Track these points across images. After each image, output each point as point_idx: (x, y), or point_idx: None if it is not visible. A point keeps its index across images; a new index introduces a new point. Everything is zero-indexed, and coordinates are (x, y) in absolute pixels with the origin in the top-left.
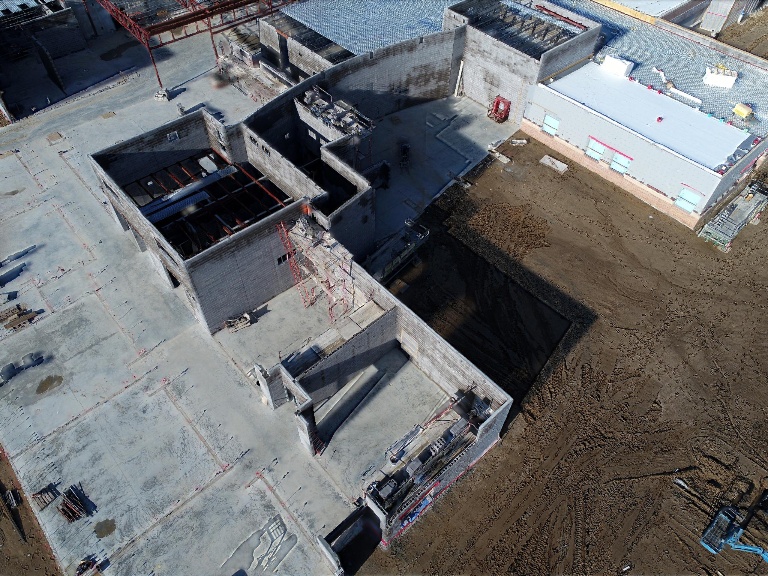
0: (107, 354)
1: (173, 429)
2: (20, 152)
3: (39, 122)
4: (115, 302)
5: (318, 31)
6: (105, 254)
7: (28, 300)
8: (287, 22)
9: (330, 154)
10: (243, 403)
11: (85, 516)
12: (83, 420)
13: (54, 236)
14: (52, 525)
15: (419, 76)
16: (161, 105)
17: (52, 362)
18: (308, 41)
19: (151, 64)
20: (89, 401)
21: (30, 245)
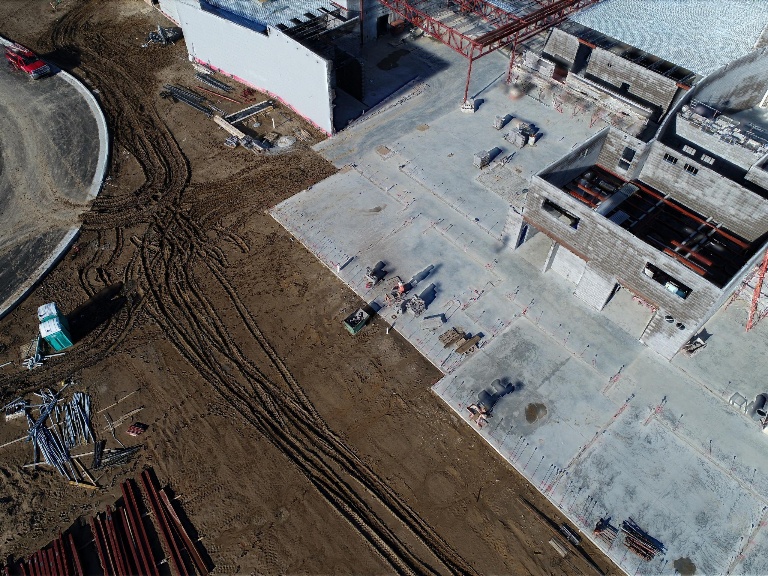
0: (575, 380)
1: (690, 461)
2: (358, 166)
3: (358, 135)
4: (549, 325)
5: (623, 40)
6: (508, 274)
7: (461, 323)
8: (580, 31)
9: (767, 173)
10: (744, 433)
11: (661, 554)
12: (593, 451)
13: (446, 255)
14: (630, 564)
15: (743, 87)
16: (469, 117)
17: (524, 389)
18: (614, 51)
19: (433, 74)
20: (587, 431)
21: (427, 265)
